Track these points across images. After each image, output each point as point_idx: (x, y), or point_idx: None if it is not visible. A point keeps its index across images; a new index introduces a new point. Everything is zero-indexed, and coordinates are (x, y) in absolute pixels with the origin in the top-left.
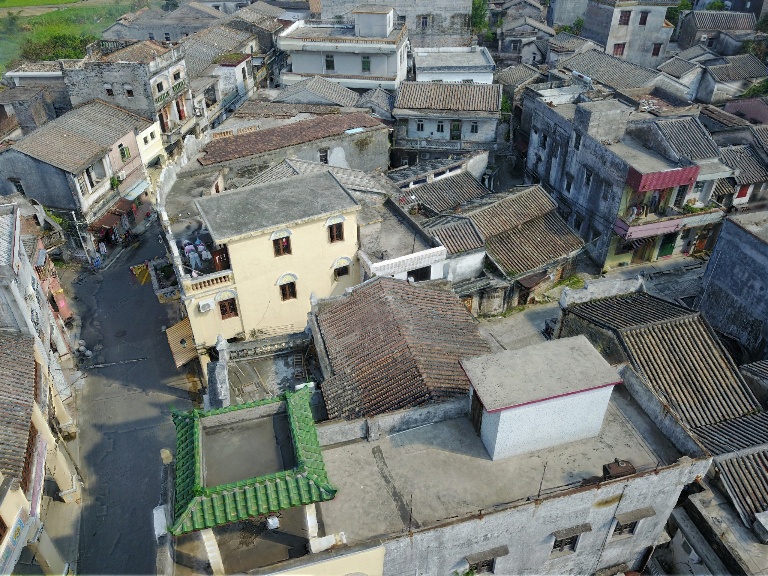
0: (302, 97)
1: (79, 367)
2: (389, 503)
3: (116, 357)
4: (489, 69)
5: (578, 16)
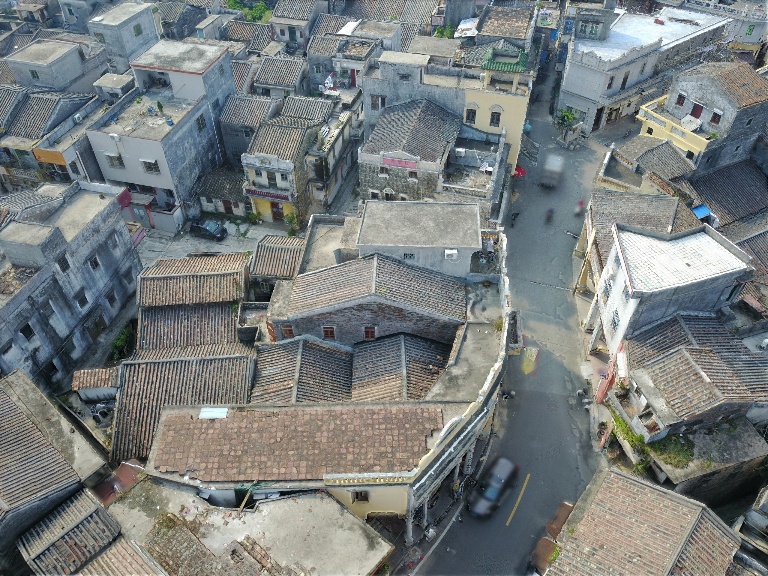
0: None
1: (577, 291)
2: (462, 84)
3: (556, 381)
4: None
5: None
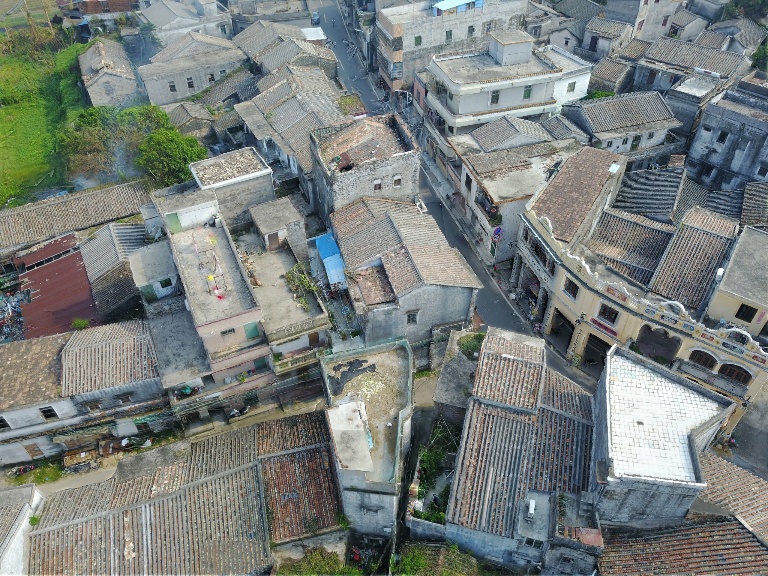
0: (516, 141)
1: None
2: None
3: None
4: (588, 70)
5: (601, 0)
